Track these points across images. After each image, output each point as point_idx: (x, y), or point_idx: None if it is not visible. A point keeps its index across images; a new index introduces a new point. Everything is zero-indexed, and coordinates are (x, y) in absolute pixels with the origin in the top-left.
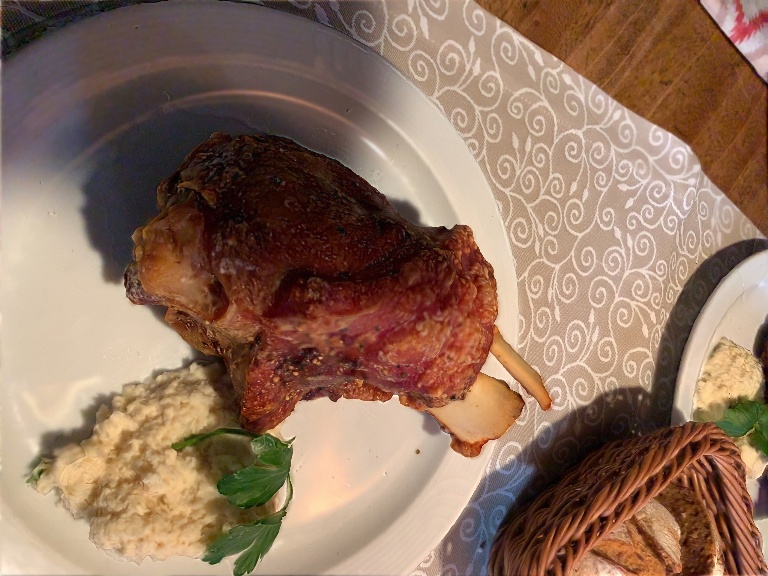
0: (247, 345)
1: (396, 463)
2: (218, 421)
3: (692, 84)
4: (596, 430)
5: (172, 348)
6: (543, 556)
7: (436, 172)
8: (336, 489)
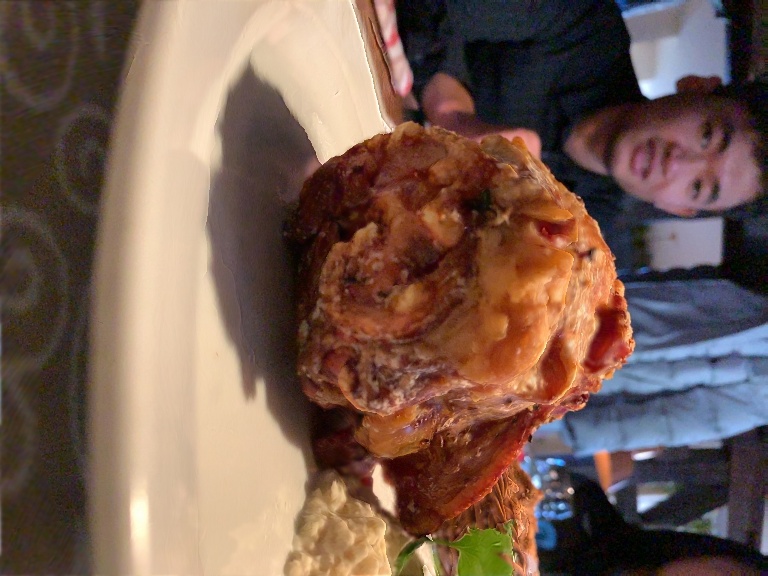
0: (503, 419)
1: None
2: (387, 547)
3: (377, 86)
4: None
5: (296, 475)
6: None
7: None
8: None
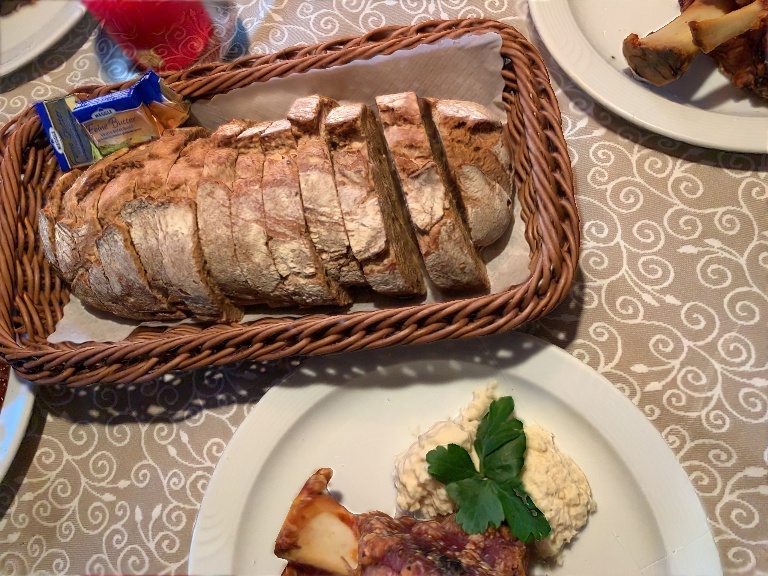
0: None
1: None
2: None
3: None
4: None
5: None
6: None
7: None
8: (607, 1)
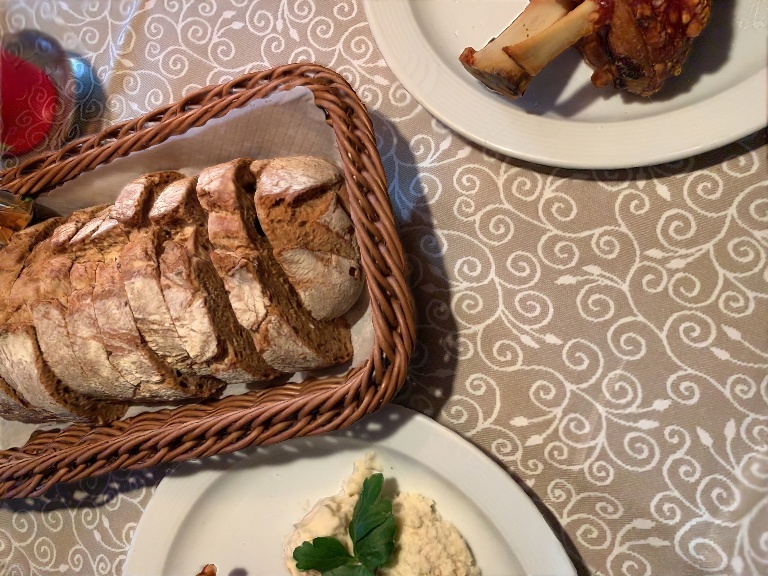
0: None
1: (462, 46)
2: None
3: None
4: (419, 316)
5: None
6: (353, 92)
7: (764, 72)
8: None
